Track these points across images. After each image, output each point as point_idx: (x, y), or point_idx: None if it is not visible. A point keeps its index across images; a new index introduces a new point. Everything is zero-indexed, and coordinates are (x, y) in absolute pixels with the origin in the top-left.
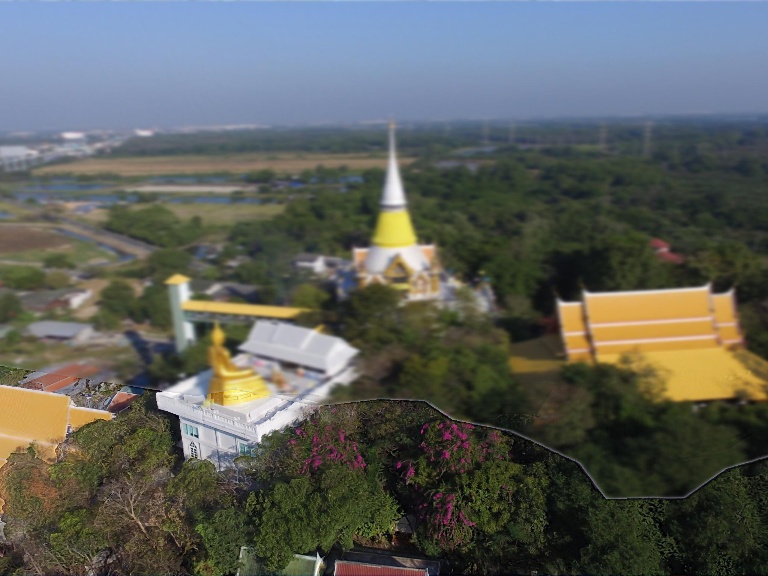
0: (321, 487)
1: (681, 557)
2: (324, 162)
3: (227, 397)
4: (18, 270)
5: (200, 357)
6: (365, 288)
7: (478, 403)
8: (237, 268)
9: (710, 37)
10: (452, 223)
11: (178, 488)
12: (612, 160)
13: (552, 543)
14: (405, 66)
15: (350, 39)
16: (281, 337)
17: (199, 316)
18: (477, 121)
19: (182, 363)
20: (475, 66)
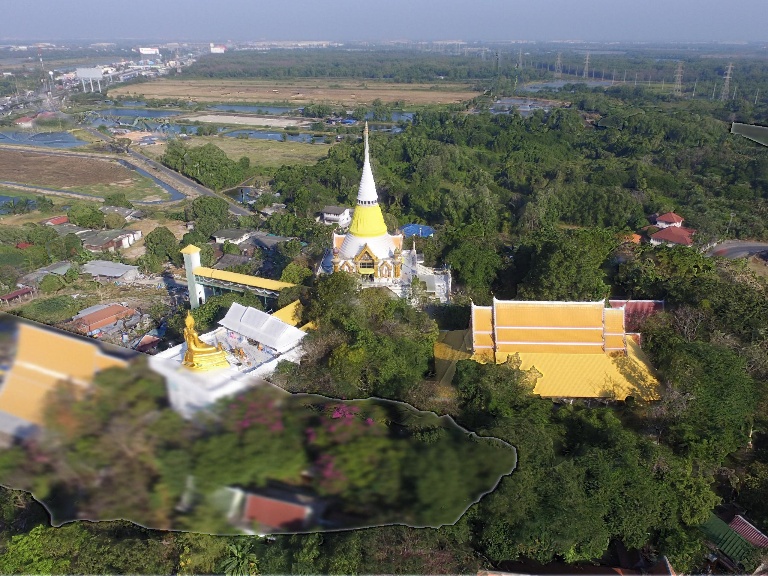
0: None
1: (479, 518)
2: (1, 436)
3: None
4: None
5: None
6: (15, 464)
7: (42, 495)
8: None
9: (63, 432)
10: (29, 455)
11: None
12: (51, 451)
13: None
14: (12, 421)
15: (0, 413)
16: (0, 471)
17: None
18: (28, 435)
19: None
20: (25, 425)
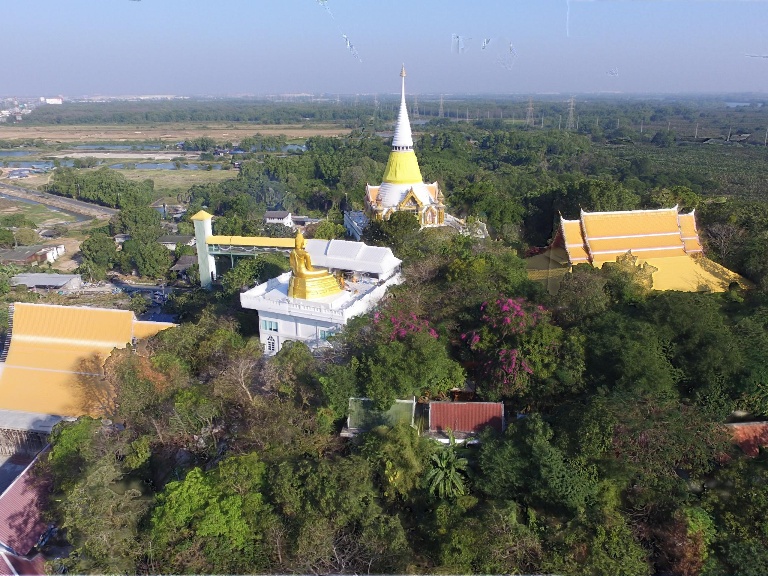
0: (413, 347)
1: (688, 381)
2: None
3: (309, 292)
4: (661, 11)
5: (729, 42)
6: None
7: None
8: (748, 8)
9: None
10: None
11: (283, 361)
12: None
13: (590, 383)
14: None
15: None
16: (759, 34)
17: (731, 26)
18: None
19: (721, 45)
20: None
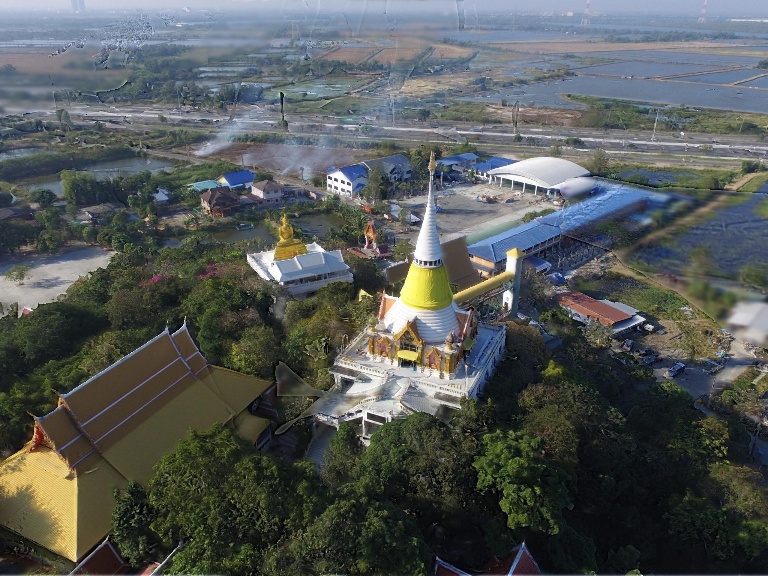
0: None
1: None
2: None
3: None
4: None
5: None
6: None
7: None
8: None
9: None
10: None
11: None
12: None
13: None
14: None
15: None
16: None
17: None
18: None
19: None
20: None
